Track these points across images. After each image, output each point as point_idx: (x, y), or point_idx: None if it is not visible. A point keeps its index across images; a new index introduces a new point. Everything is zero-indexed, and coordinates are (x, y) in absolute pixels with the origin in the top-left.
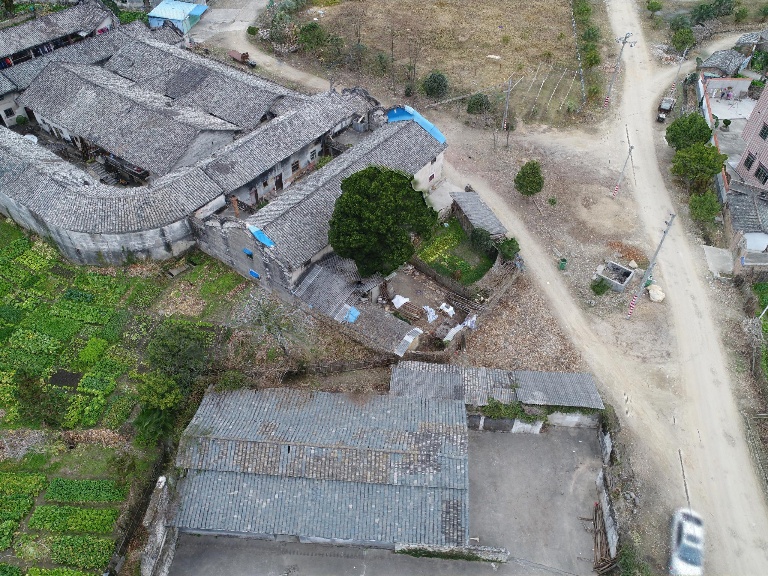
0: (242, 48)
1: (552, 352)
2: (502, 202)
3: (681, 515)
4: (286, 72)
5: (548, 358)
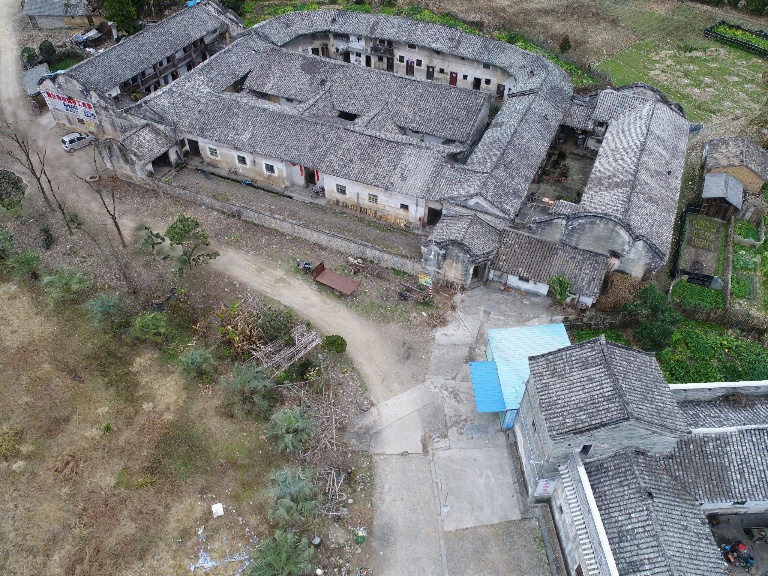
0: (349, 326)
1: (34, 44)
2: (7, 113)
3: (15, 7)
4: (246, 267)
5: (38, 42)
